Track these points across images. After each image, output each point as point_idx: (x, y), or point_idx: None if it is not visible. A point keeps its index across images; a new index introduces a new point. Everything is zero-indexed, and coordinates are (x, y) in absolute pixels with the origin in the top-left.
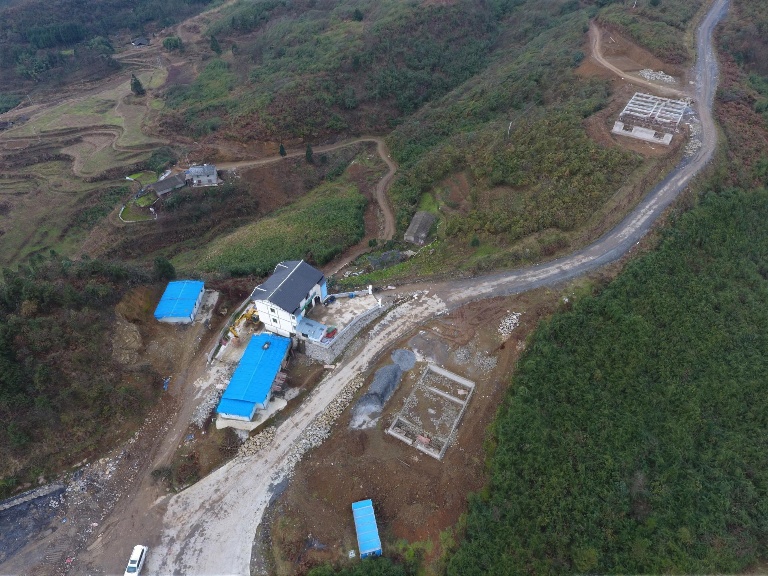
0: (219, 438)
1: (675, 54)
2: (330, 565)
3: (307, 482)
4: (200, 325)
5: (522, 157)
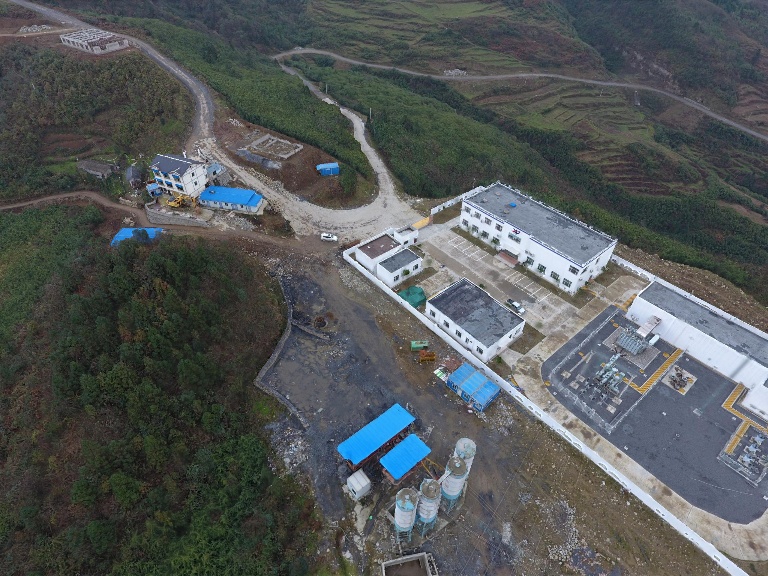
0: (267, 217)
1: (26, 11)
2: (340, 179)
3: (301, 190)
4: (169, 232)
5: (82, 93)
